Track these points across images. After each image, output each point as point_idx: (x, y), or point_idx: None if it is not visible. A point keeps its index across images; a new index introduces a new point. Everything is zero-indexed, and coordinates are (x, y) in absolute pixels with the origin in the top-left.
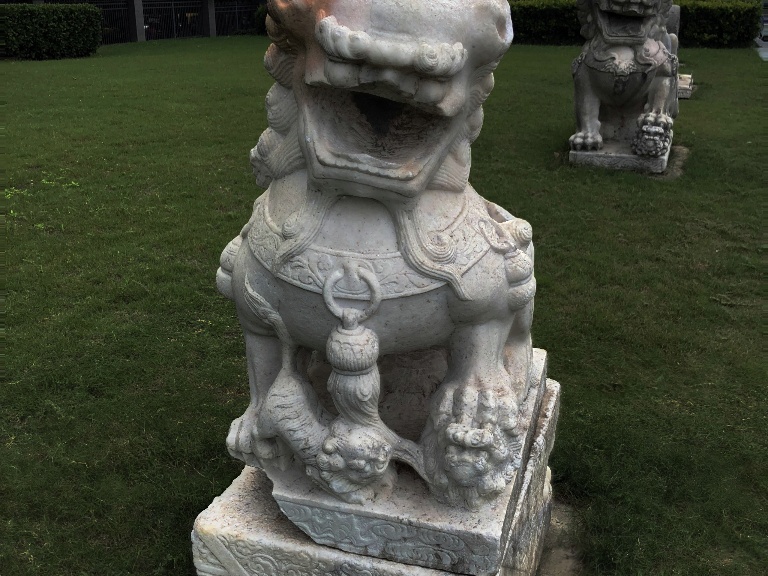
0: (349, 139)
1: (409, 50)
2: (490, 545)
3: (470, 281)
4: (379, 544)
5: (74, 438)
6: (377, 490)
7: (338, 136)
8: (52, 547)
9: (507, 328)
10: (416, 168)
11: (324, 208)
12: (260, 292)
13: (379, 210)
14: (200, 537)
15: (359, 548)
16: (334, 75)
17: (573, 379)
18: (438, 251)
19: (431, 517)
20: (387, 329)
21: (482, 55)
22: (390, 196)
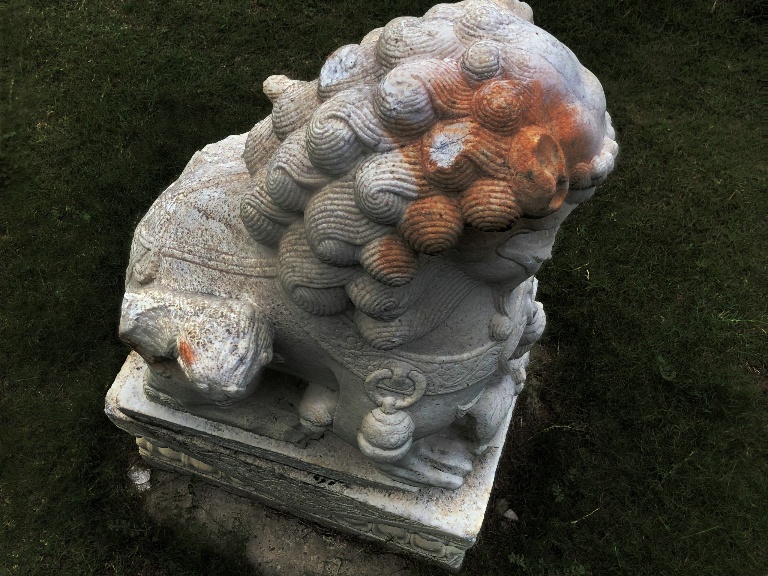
0: None
1: None
2: None
3: None
4: None
5: None
6: None
7: None
8: None
9: None
10: None
11: None
12: None
13: None
14: None
15: None
16: None
17: None
18: None
19: None
20: None
21: None
22: None
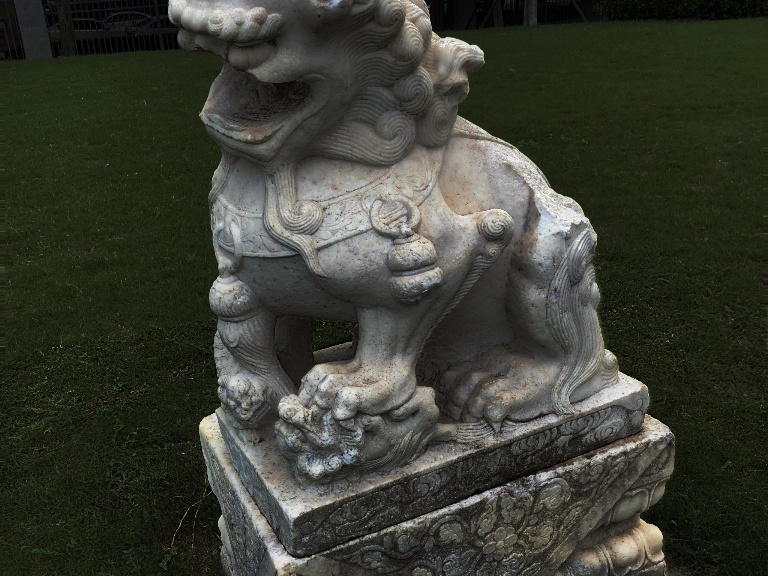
0: (242, 100)
1: (201, 16)
2: (286, 522)
3: (328, 257)
4: (251, 486)
5: None
6: (267, 438)
7: (233, 97)
8: None
9: (406, 321)
10: (263, 133)
11: (228, 163)
12: None
13: None
14: None
15: (246, 483)
16: None
17: None
18: (291, 219)
19: (271, 477)
20: (258, 286)
21: (306, 20)
22: (247, 158)
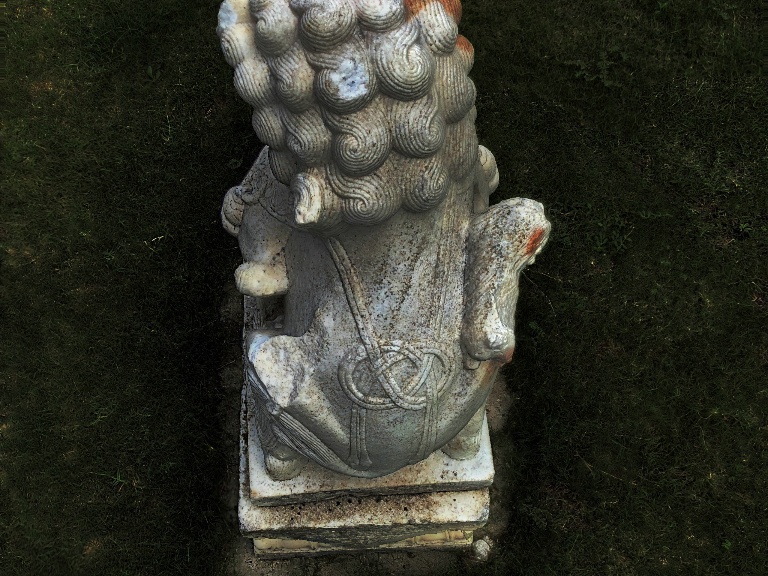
0: None
1: None
2: None
3: None
4: None
5: (761, 458)
6: None
7: None
8: None
9: None
10: None
11: None
12: None
13: None
14: None
15: None
16: None
17: None
18: None
19: None
20: None
21: None
22: None
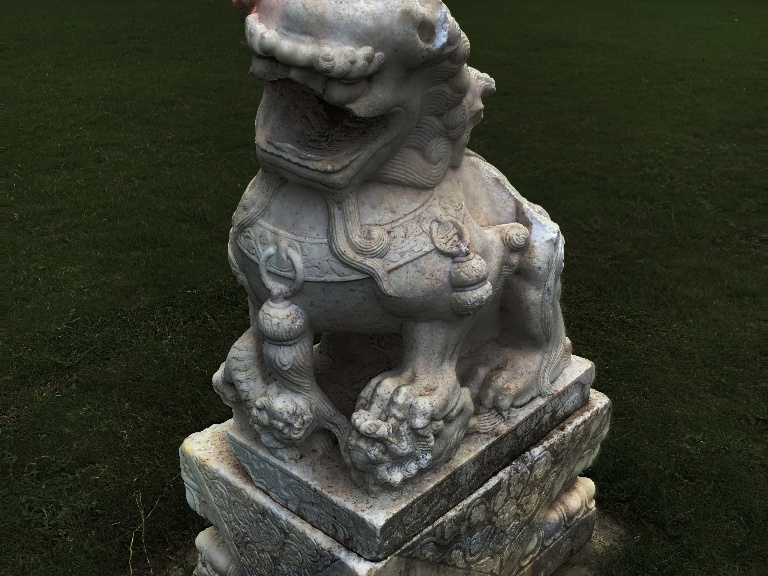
0: (296, 127)
1: (307, 52)
2: (371, 531)
3: (398, 278)
4: (295, 501)
5: (212, 348)
6: (306, 453)
7: (285, 123)
8: (145, 433)
9: (457, 331)
10: (341, 162)
11: (272, 188)
12: (234, 254)
13: (318, 197)
14: (183, 454)
15: (282, 500)
16: (254, 68)
17: (717, 402)
18: (363, 244)
19: (334, 490)
20: (314, 309)
21: (406, 59)
22: (316, 186)
